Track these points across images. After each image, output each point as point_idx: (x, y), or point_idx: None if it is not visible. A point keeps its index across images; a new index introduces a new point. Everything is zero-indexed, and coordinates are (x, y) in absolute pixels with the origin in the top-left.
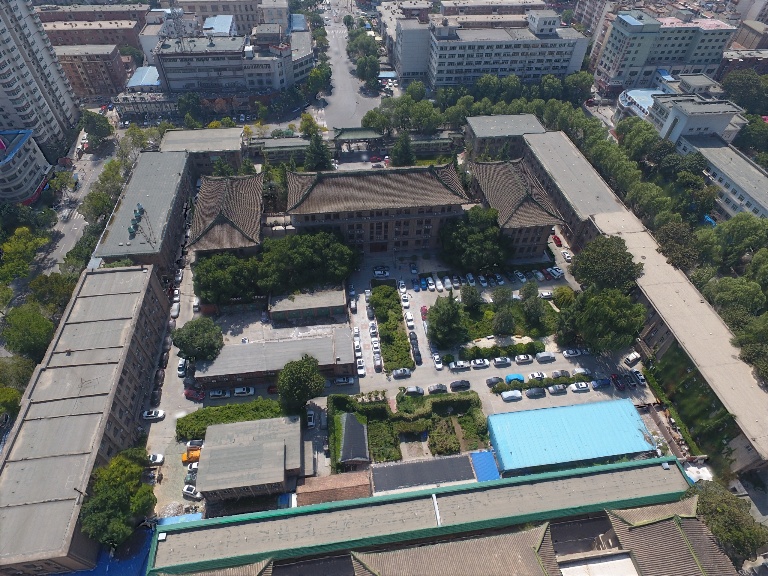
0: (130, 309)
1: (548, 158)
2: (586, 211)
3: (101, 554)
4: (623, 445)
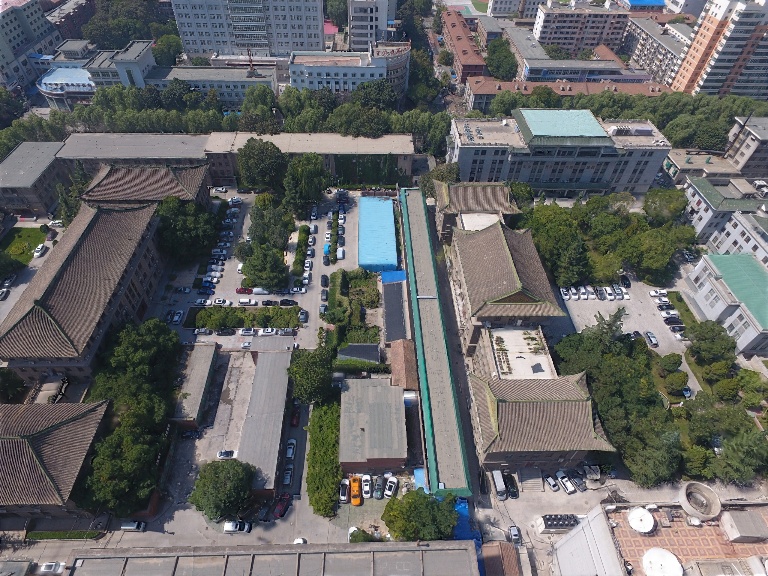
0: (157, 567)
1: (108, 152)
2: (196, 153)
3: None
4: (388, 210)
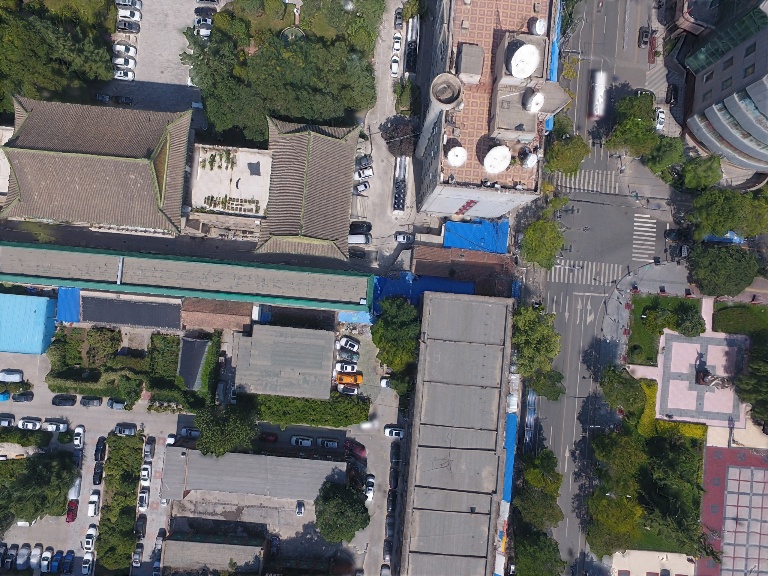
0: (415, 568)
1: None
2: None
3: (417, 303)
4: None
